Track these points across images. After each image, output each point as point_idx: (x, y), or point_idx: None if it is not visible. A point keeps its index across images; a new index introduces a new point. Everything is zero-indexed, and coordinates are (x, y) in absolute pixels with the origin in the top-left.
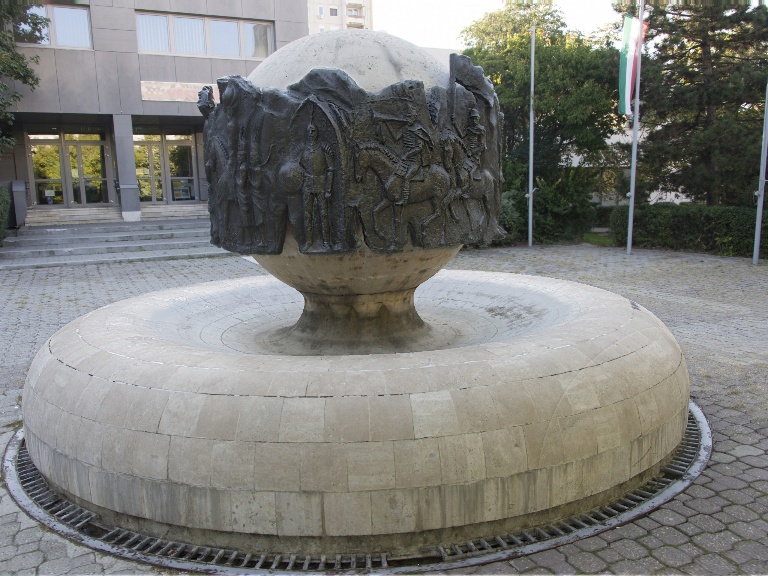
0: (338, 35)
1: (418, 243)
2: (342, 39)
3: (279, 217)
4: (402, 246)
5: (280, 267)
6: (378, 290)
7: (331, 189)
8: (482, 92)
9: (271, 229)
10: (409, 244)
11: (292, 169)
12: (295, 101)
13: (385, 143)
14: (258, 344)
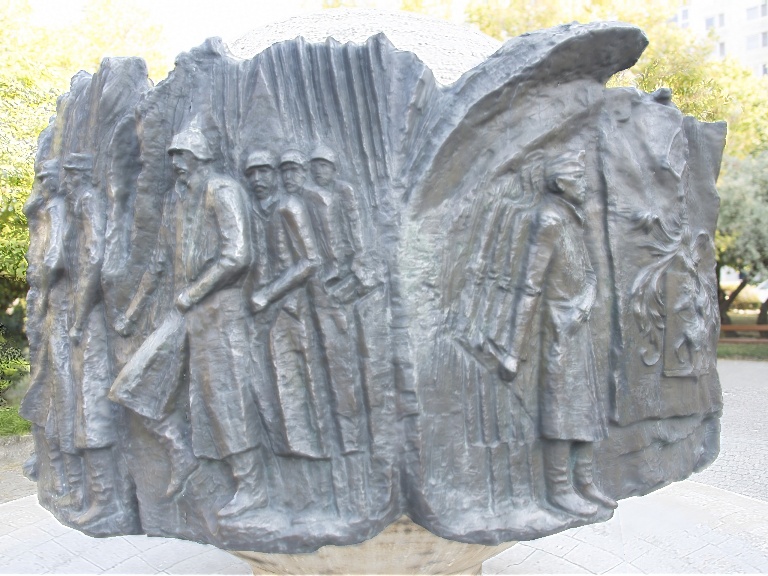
0: None
1: None
2: None
3: None
4: None
5: None
6: None
7: None
8: None
9: None
10: None
11: None
12: None
13: None
14: (494, 568)
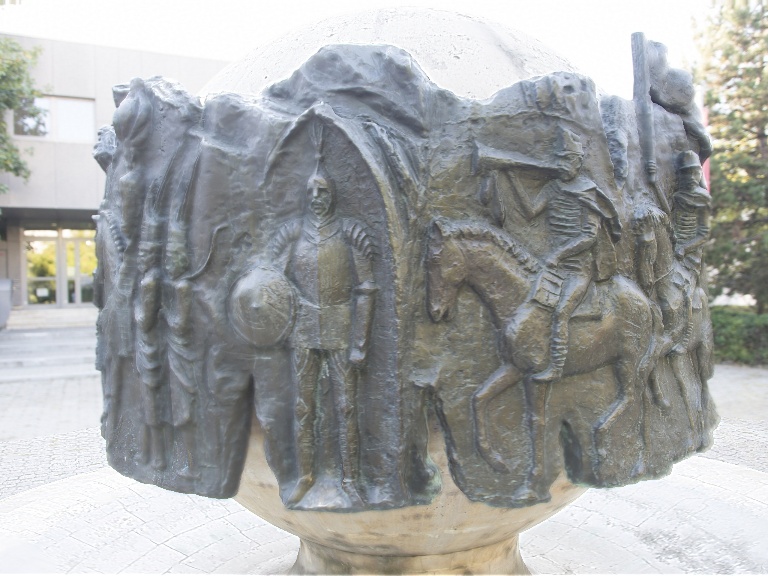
0: (380, 6)
1: (585, 475)
2: (389, 9)
3: (230, 407)
4: (547, 487)
5: (243, 497)
6: (460, 547)
7: (365, 340)
8: (694, 119)
9: (209, 436)
10: (560, 476)
11: (265, 287)
12: (277, 118)
13: (504, 223)
14: None
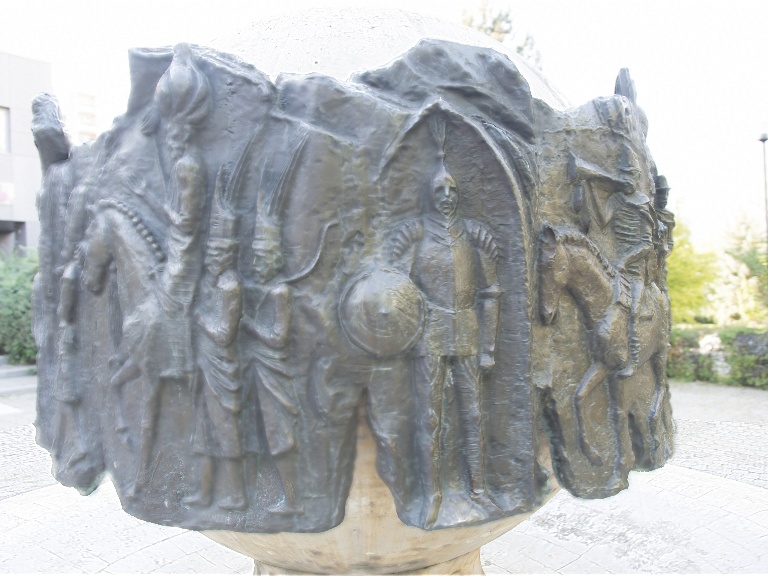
0: None
1: (643, 461)
2: (408, 10)
3: (343, 426)
4: (626, 474)
5: None
6: None
7: (494, 344)
8: None
9: (316, 462)
10: None
11: (393, 291)
12: (396, 109)
13: (587, 230)
14: None
